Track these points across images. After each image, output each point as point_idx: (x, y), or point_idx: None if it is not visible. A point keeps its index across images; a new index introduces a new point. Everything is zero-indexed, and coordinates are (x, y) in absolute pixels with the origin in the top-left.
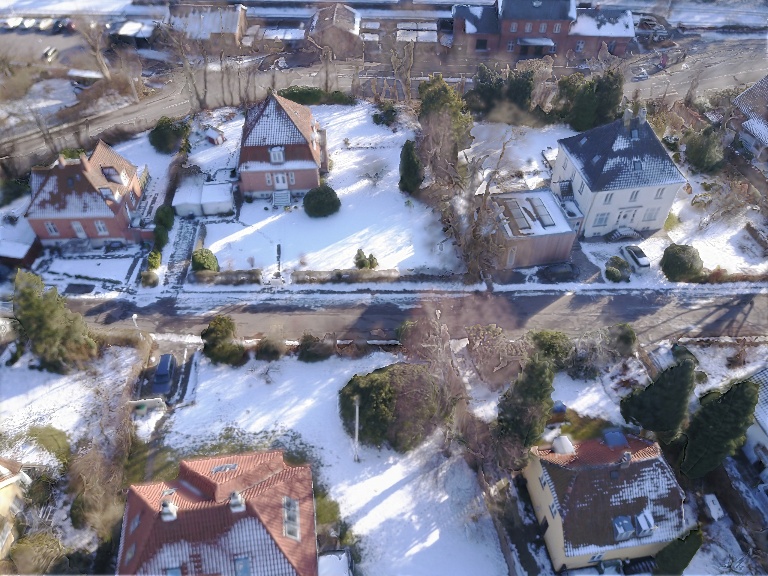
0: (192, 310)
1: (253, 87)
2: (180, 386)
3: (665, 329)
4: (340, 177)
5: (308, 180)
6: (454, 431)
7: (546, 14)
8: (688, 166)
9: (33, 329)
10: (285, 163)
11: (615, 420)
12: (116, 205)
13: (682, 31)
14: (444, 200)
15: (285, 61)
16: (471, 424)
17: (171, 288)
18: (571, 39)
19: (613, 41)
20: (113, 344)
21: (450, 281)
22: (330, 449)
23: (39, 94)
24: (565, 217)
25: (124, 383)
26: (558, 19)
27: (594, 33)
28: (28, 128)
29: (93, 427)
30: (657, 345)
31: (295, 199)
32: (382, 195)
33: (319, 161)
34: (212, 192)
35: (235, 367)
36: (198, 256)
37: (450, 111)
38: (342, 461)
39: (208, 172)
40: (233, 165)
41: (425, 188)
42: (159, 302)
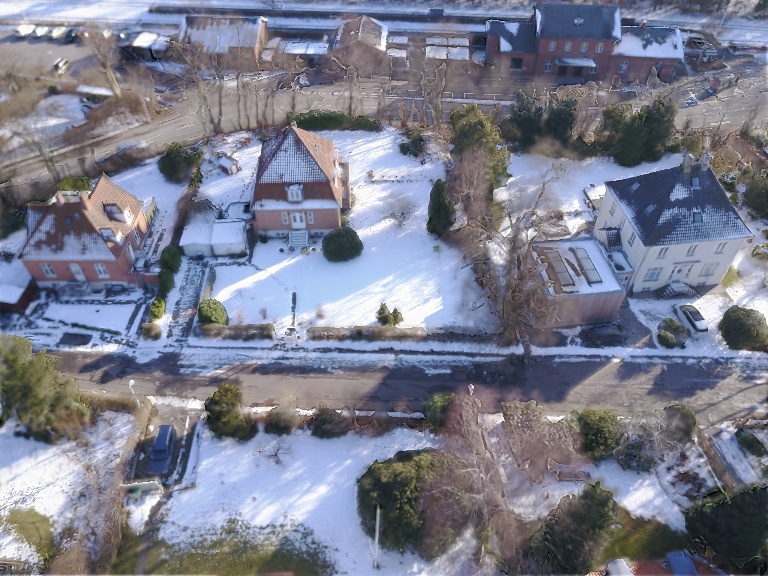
0: (197, 369)
1: (271, 110)
2: (180, 462)
3: (727, 408)
4: (363, 215)
5: (328, 220)
6: (494, 561)
7: (588, 33)
8: (747, 210)
9: (18, 398)
10: (303, 202)
11: (673, 523)
12: (118, 247)
13: (733, 51)
14: (481, 260)
15: (306, 78)
16: (508, 529)
17: (175, 341)
18: (614, 59)
19: (660, 62)
20: (108, 409)
21: (483, 342)
22: (346, 551)
23: (46, 111)
24: (613, 272)
25: (118, 458)
26: (601, 38)
27: (639, 54)
28: (32, 150)
29: (80, 513)
30: (718, 428)
31: (313, 240)
32: (408, 237)
33: (341, 200)
34: (223, 231)
35: (241, 441)
36: (205, 308)
37: (486, 147)
38: (359, 567)
39: (220, 206)
40: (247, 198)
41: (456, 231)
42: (161, 358)
